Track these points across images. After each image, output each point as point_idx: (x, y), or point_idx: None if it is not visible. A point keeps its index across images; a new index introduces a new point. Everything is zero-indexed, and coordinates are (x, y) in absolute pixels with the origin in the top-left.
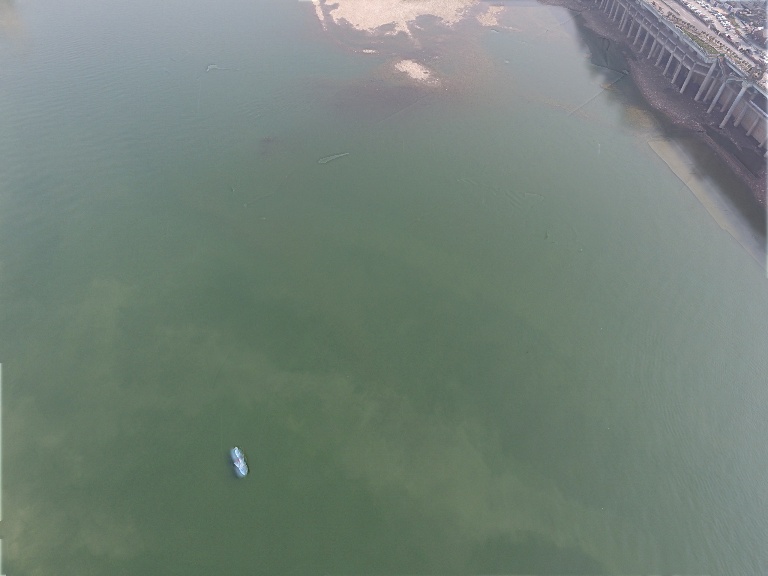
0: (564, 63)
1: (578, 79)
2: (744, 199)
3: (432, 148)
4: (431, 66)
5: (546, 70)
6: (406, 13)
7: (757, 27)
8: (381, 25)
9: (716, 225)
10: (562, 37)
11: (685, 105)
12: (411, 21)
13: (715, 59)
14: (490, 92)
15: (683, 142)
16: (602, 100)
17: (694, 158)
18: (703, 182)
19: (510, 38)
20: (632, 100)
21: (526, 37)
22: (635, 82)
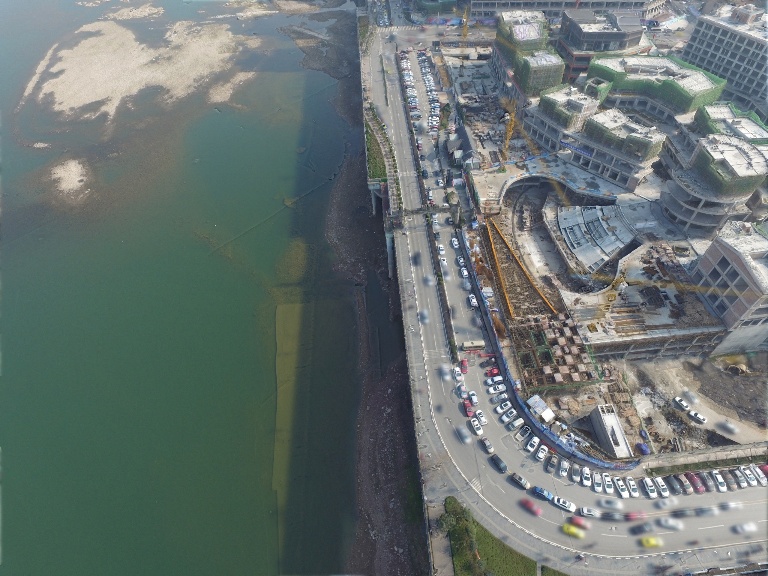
0: (274, 159)
1: (266, 188)
2: (341, 421)
3: (17, 306)
4: (96, 169)
5: (247, 170)
6: (132, 84)
7: (449, 134)
8: (88, 103)
9: (268, 479)
10: (290, 120)
11: (365, 236)
12: (129, 96)
13: (377, 185)
14: (137, 213)
15: (324, 305)
16: (270, 226)
17: (320, 336)
18: (303, 386)
19: (230, 121)
20: (307, 226)
21: (249, 120)
22: (330, 195)
